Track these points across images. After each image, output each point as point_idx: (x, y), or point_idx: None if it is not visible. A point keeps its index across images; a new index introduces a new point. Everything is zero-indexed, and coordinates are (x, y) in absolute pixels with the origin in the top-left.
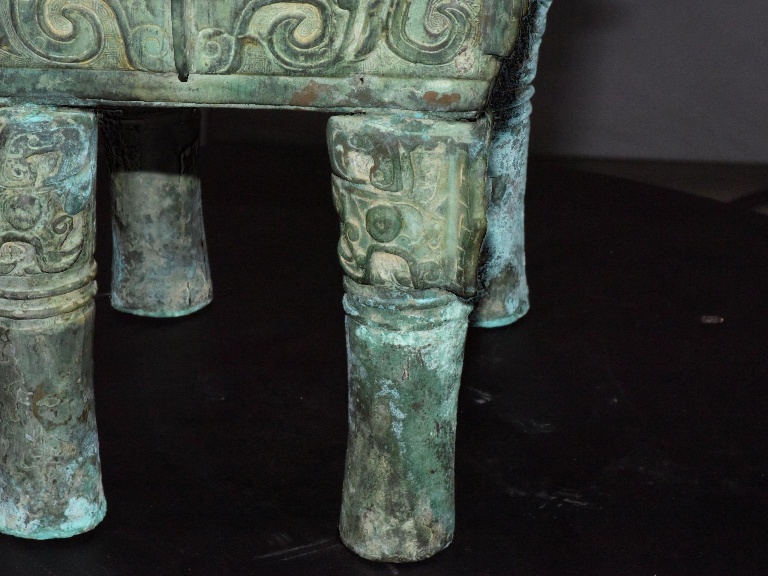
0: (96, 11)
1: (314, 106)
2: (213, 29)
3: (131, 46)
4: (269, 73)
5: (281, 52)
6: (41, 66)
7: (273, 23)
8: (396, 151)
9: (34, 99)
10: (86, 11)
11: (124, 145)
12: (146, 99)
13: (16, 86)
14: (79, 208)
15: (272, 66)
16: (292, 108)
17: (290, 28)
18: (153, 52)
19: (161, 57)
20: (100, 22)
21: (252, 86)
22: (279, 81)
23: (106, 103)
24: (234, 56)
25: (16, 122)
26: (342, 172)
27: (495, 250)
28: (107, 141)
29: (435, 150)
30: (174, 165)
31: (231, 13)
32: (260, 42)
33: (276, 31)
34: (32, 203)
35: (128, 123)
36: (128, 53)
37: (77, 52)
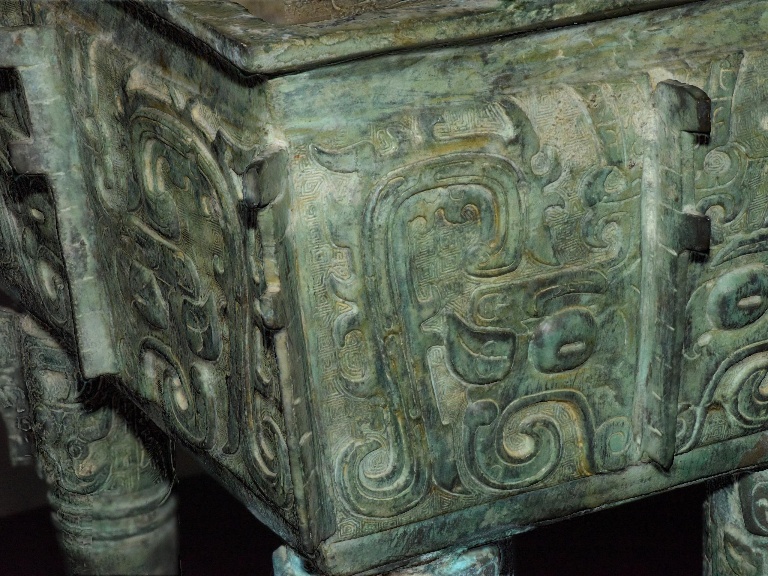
0: (556, 417)
1: (761, 463)
2: (680, 404)
3: (595, 448)
4: (726, 438)
5: (743, 411)
6: (490, 500)
7: (740, 380)
8: None
9: (468, 542)
10: (548, 420)
11: (127, 567)
12: (593, 506)
13: (458, 532)
14: None
15: (731, 430)
16: (734, 471)
17: (758, 381)
18: (617, 448)
19: (625, 452)
20: (559, 429)
21: (704, 458)
22: (731, 445)
23: (544, 523)
24: (698, 429)
25: (444, 575)
26: (765, 529)
27: (508, 569)
28: (96, 568)
29: None
30: (177, 574)
31: (701, 381)
32: (723, 406)
33: (743, 389)
34: None
35: (134, 540)
36: (591, 457)
37: (535, 472)
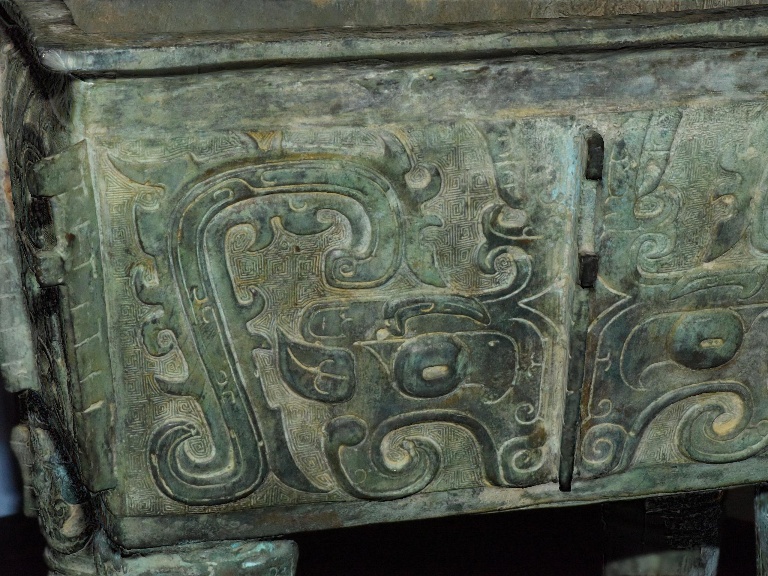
0: None
1: None
2: None
3: None
4: None
5: None
6: None
7: None
8: (95, 554)
9: None
10: None
11: None
12: None
13: None
14: (76, 499)
15: None
16: None
17: None
18: None
19: None
20: None
21: None
22: None
23: None
24: None
25: None
26: None
27: None
28: None
29: (121, 573)
30: None
31: None
32: None
33: None
34: (38, 473)
35: None
36: None
37: None
